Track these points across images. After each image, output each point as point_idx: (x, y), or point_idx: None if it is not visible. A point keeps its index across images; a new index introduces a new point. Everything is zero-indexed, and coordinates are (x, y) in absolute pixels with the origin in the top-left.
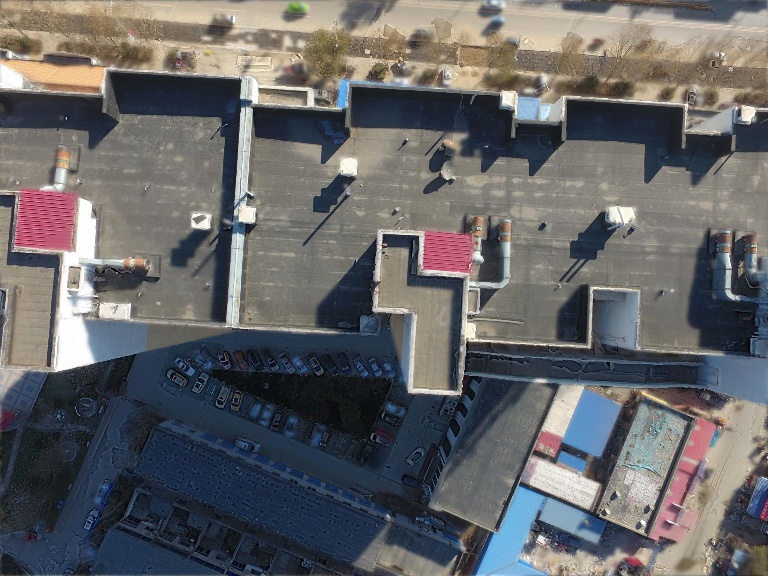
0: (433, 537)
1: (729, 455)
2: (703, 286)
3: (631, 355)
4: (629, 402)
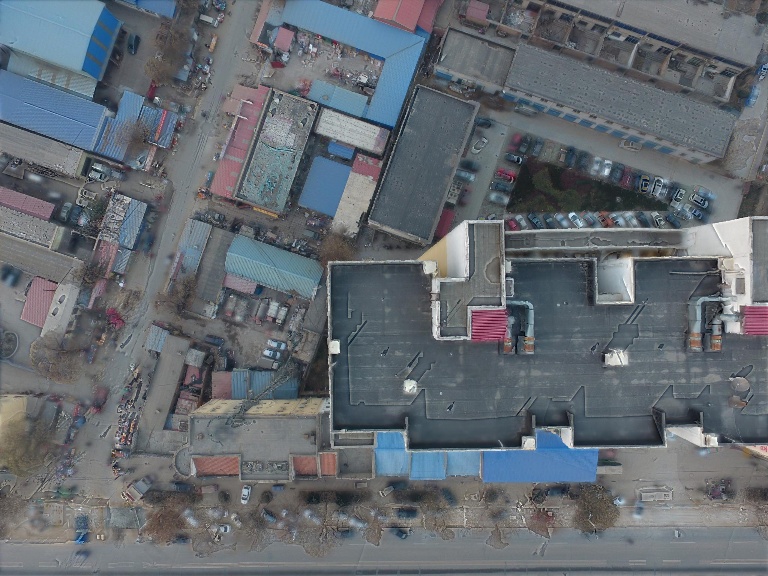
0: (464, 76)
1: (193, 165)
2: (535, 310)
3: (558, 254)
4: (288, 207)
